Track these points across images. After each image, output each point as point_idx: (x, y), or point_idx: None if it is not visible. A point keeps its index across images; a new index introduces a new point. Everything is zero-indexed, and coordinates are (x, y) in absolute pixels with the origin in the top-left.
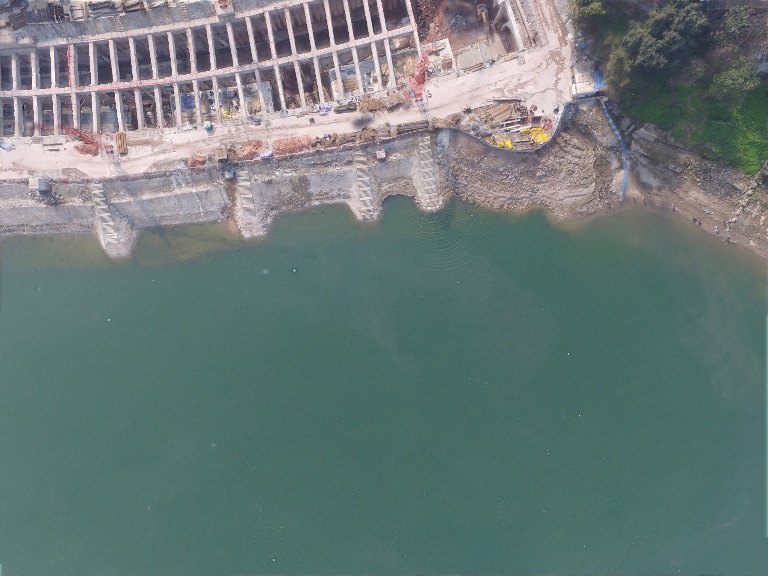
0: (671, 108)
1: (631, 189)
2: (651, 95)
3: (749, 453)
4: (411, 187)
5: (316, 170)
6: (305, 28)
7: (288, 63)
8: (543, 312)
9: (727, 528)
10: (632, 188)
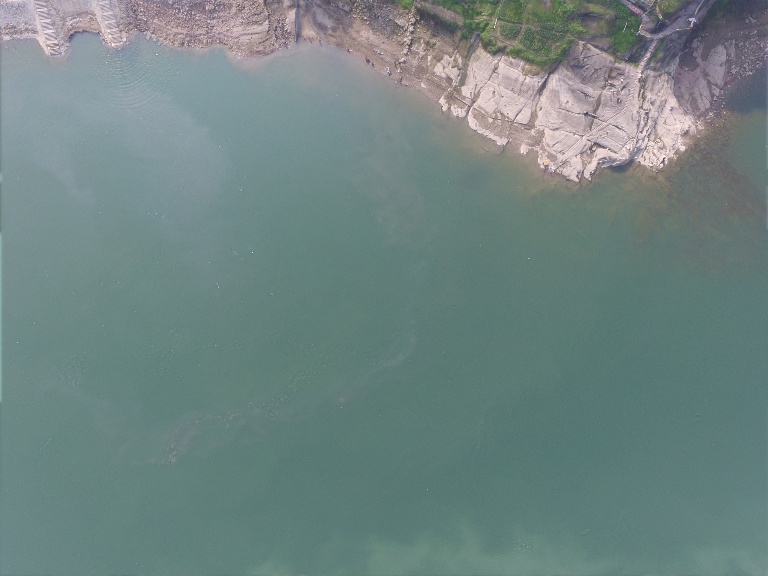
0: None
1: (307, 30)
2: None
3: (415, 294)
4: (96, 23)
5: None
6: None
7: None
8: (220, 149)
9: (391, 368)
10: (308, 29)
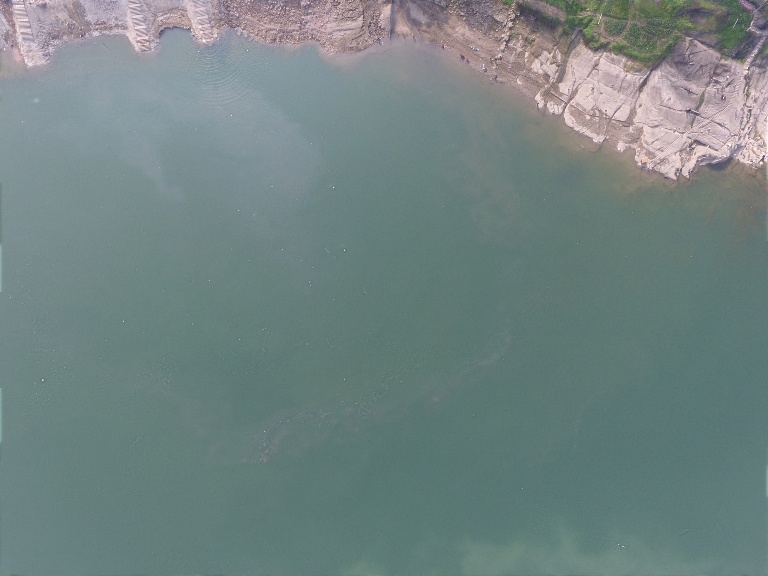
0: None
1: (401, 25)
2: None
3: (510, 292)
4: (186, 19)
5: None
6: None
7: None
8: (312, 146)
9: (485, 367)
10: (402, 25)
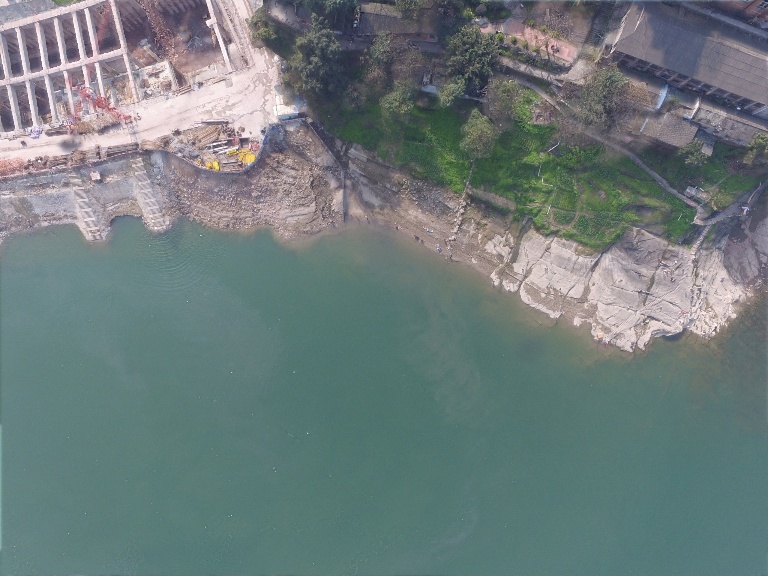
0: (369, 129)
1: (354, 208)
2: (345, 117)
3: (475, 470)
4: (137, 207)
5: (34, 192)
6: (38, 51)
7: (2, 87)
8: (270, 330)
9: (454, 545)
10: (355, 207)
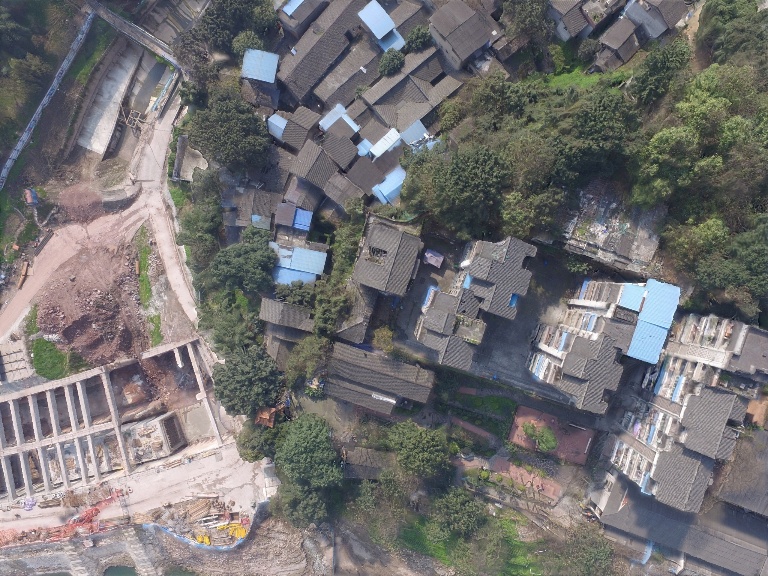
0: None
1: (345, 561)
2: None
3: None
4: (130, 559)
5: (29, 555)
6: None
7: None
8: None
9: None
10: (346, 560)
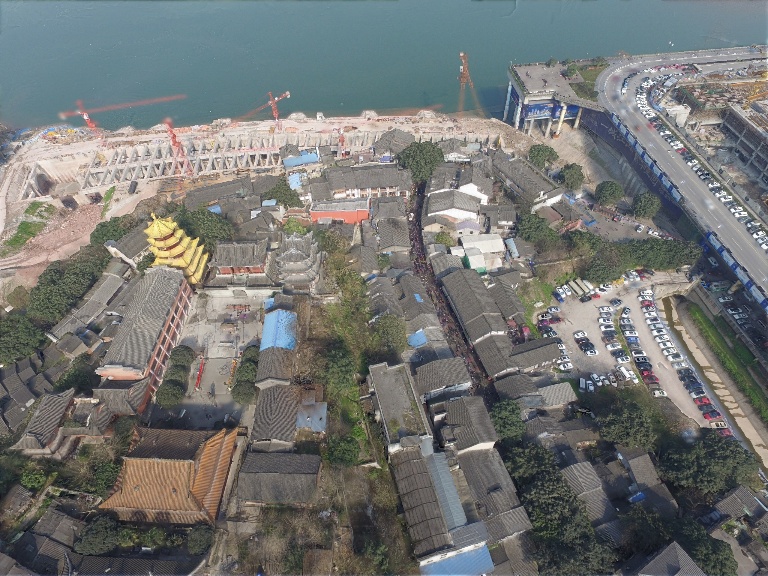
0: None
1: None
2: None
3: None
4: None
5: None
6: None
7: None
8: None
9: None
10: None
